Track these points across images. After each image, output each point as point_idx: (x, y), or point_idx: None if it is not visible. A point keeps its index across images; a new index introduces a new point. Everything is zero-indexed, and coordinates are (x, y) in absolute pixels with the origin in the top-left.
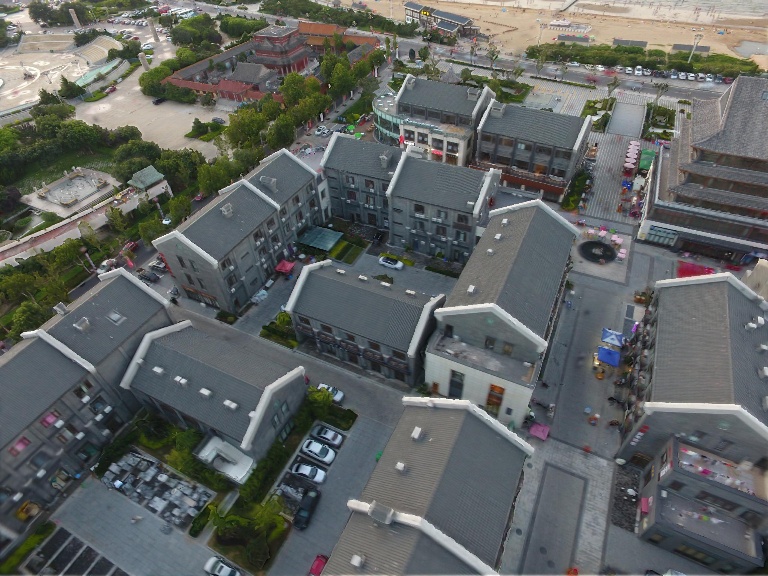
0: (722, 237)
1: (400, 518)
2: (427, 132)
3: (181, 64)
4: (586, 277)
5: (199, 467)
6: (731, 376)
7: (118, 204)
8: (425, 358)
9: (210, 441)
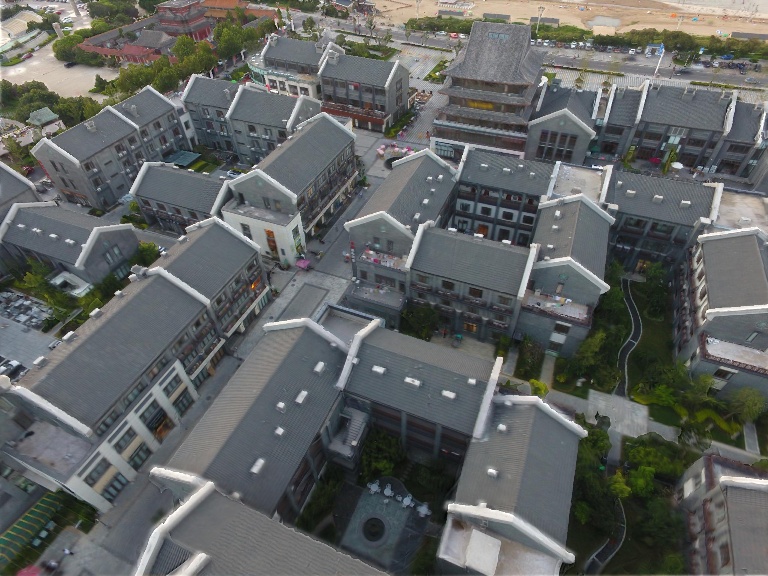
0: (481, 146)
1: (149, 270)
2: (285, 80)
3: (94, 34)
4: (382, 180)
5: (51, 290)
6: (394, 200)
7: (17, 138)
8: (223, 217)
9: (60, 274)
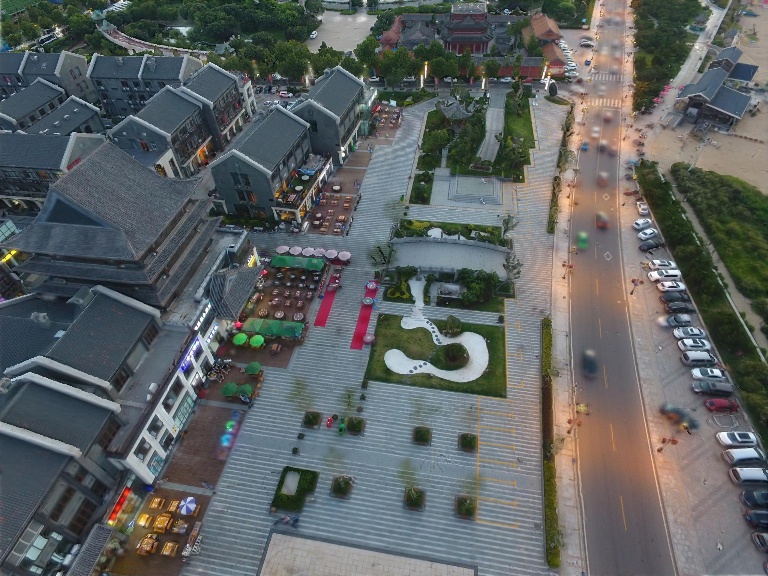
0: None
1: None
2: None
3: (434, 12)
4: None
5: None
6: None
7: None
8: None
9: None
